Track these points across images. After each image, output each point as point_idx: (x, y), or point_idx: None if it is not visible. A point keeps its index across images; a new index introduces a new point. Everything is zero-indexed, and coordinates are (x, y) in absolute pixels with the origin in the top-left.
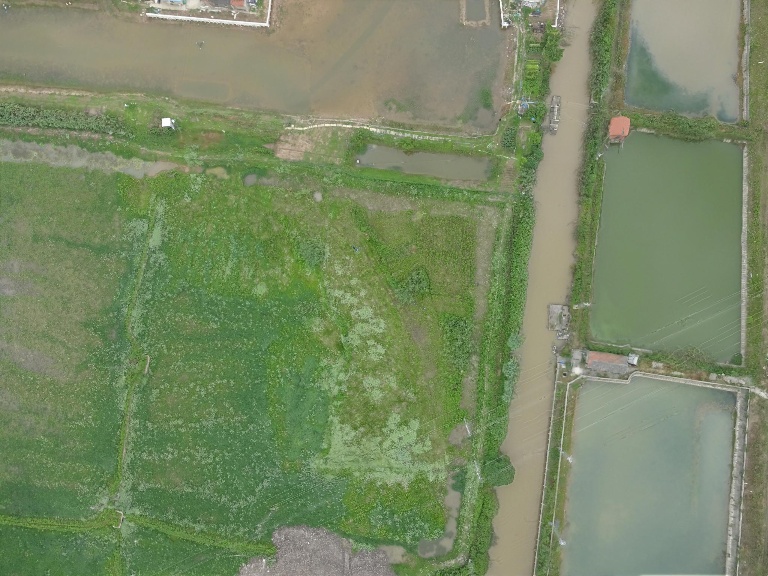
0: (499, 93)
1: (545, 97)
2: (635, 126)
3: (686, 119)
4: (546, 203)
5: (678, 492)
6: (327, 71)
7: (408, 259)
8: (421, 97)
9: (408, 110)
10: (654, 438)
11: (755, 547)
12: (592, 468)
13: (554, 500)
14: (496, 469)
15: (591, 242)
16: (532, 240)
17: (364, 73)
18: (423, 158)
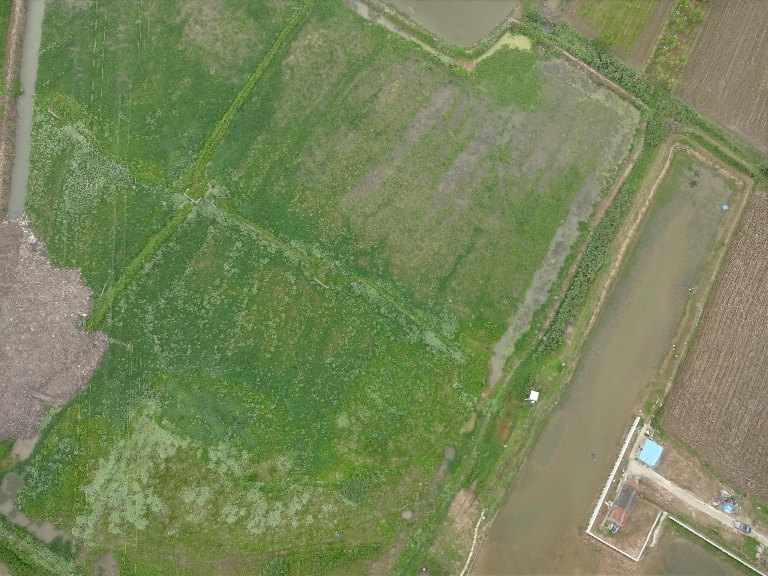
0: None
1: None
2: None
3: None
4: None
5: None
6: (523, 573)
7: None
8: None
9: None
10: None
11: None
12: None
13: None
14: None
15: None
16: None
17: None
18: None
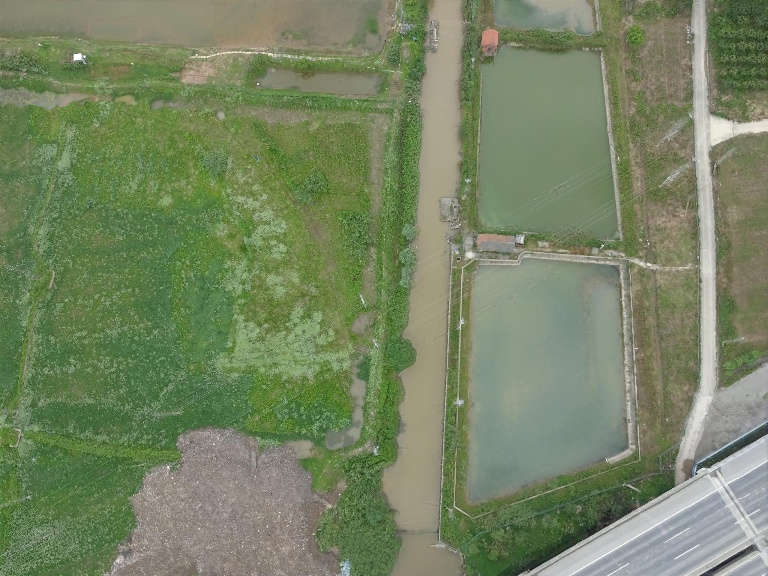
0: (384, 20)
1: (424, 21)
2: (505, 41)
3: (548, 31)
4: (432, 110)
5: (575, 364)
6: (229, 10)
7: (306, 164)
8: (314, 27)
9: (303, 38)
10: (548, 315)
11: (652, 408)
12: (492, 348)
13: (457, 380)
14: (397, 349)
15: (473, 139)
16: (421, 142)
17: (262, 10)
18: (318, 78)
